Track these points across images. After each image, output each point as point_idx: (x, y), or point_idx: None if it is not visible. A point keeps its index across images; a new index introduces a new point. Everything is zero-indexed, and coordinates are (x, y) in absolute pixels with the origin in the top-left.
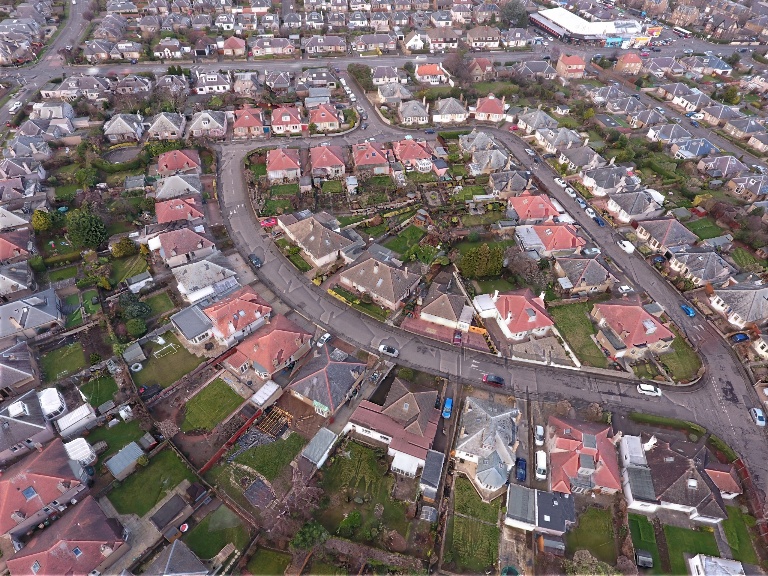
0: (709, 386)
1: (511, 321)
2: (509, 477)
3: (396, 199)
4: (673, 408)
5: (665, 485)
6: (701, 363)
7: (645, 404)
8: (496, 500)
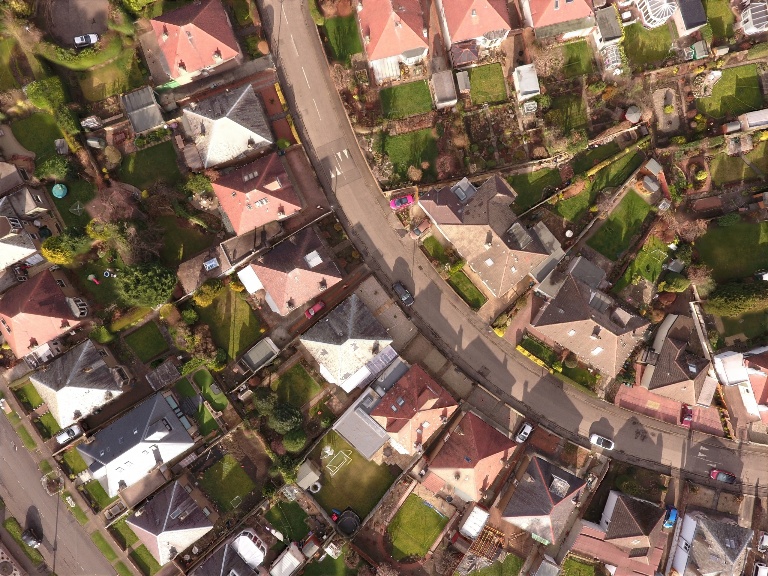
0: None
1: None
2: None
3: (608, 130)
4: None
5: None
6: None
7: None
8: None
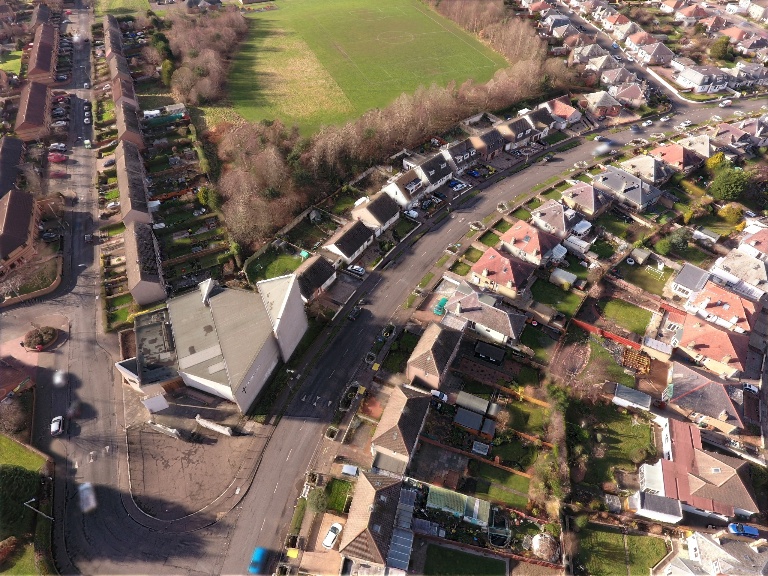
0: None
1: None
2: None
3: None
4: None
5: None
6: None
7: None
8: None
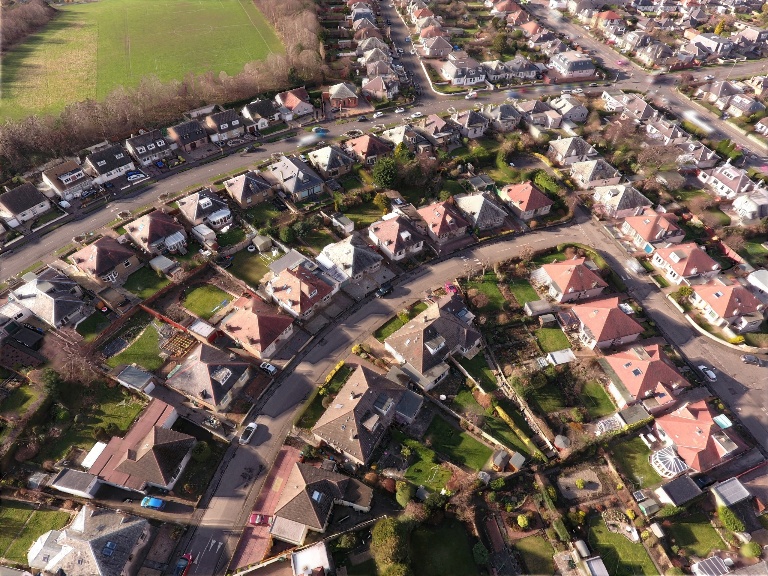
0: None
1: None
2: None
3: None
4: None
5: None
6: None
7: None
8: None
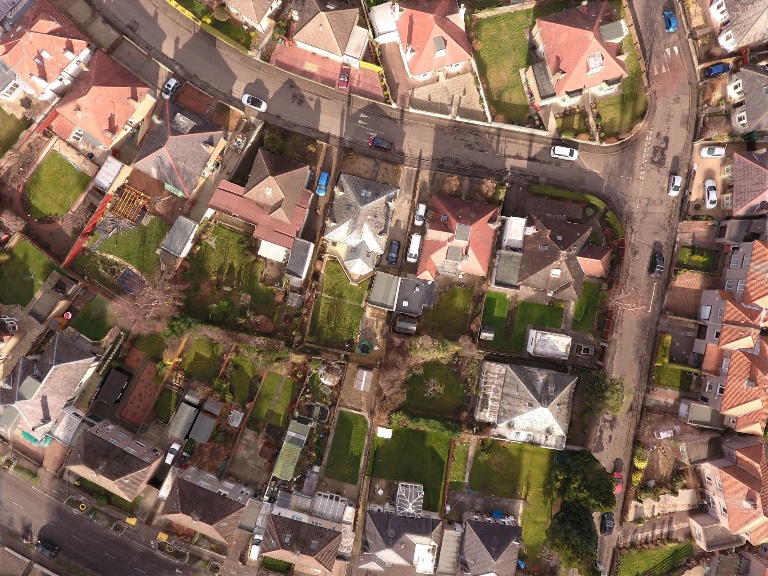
0: (640, 145)
1: (412, 56)
2: (380, 260)
3: None
4: (583, 175)
5: (530, 273)
6: (645, 112)
7: (553, 171)
8: (364, 282)
